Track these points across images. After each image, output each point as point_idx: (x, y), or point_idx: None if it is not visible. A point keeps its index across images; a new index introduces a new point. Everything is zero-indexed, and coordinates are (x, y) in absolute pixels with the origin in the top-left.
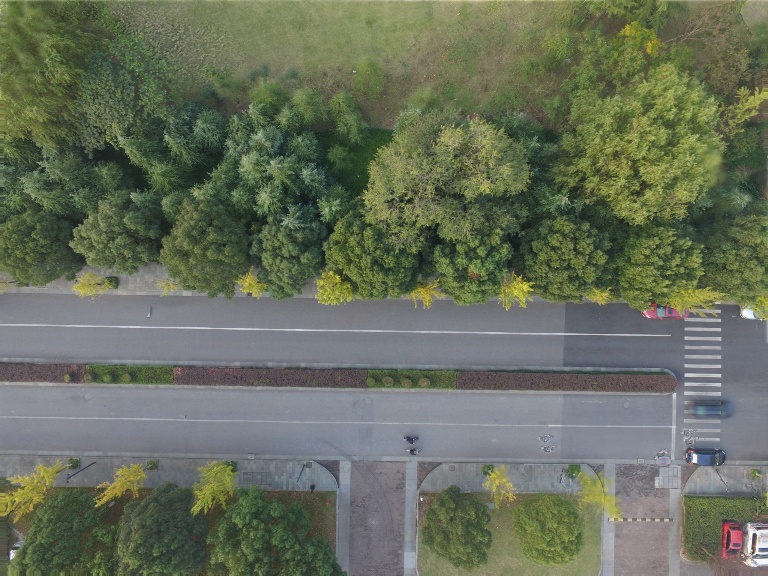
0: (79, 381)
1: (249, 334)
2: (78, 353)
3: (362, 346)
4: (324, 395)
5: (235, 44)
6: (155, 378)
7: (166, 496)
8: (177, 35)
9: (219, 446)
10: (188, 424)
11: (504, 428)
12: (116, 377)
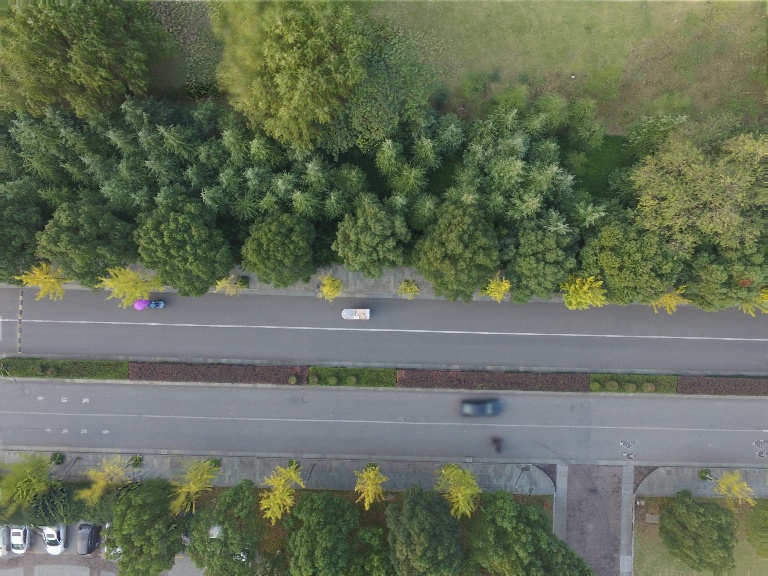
0: (302, 383)
1: (468, 337)
2: (300, 355)
3: (580, 350)
4: (542, 399)
5: (454, 48)
6: (378, 381)
7: (419, 499)
8: (396, 38)
9: (438, 449)
10: (407, 427)
11: (719, 433)
12: (339, 379)
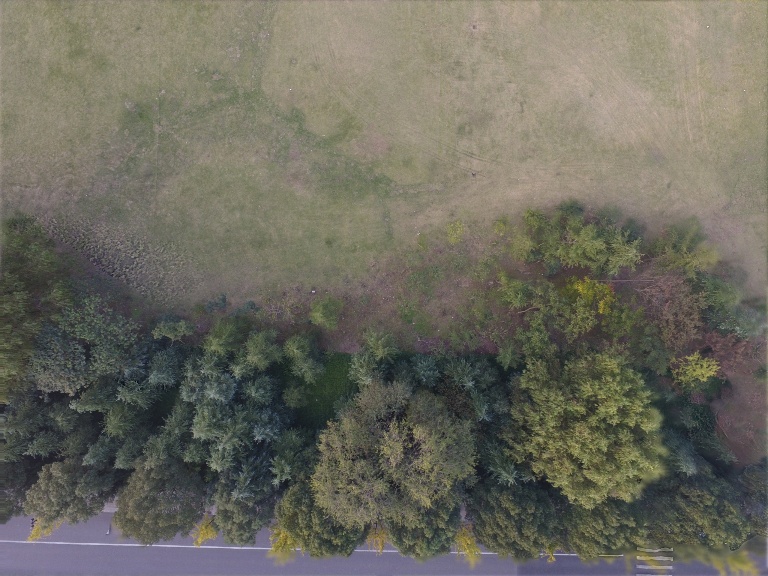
0: None
1: (207, 552)
2: (37, 571)
3: (318, 564)
4: None
5: (195, 262)
6: None
7: None
8: (137, 252)
9: None
10: None
11: None
12: None
